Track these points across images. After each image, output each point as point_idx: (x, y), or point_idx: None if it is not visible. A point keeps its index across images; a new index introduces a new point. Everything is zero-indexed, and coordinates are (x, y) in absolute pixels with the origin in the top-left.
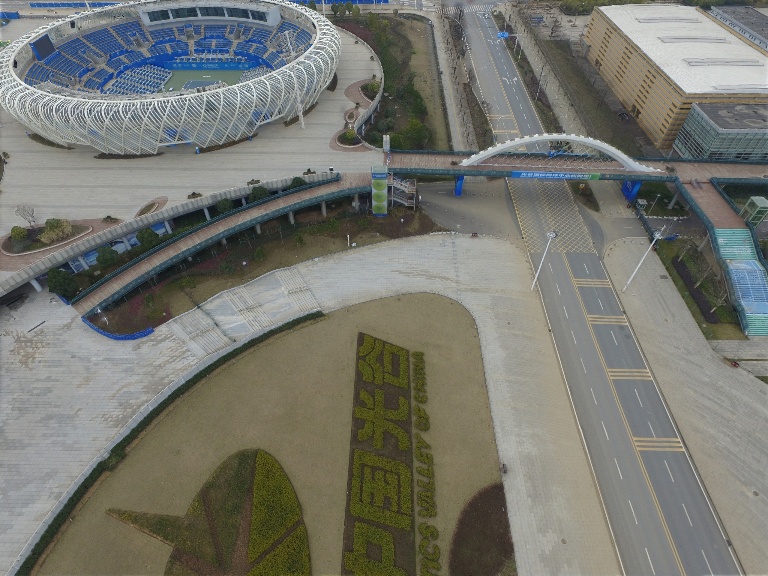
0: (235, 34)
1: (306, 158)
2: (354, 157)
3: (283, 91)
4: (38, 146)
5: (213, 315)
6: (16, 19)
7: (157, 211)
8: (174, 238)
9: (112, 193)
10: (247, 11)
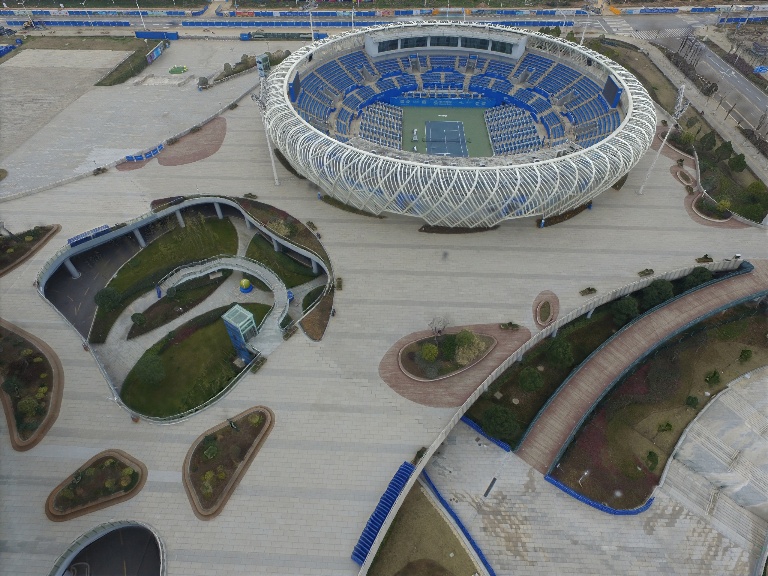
0: (466, 66)
1: (679, 236)
2: (738, 236)
3: (641, 152)
4: (340, 213)
5: (700, 470)
6: (175, 40)
7: (565, 316)
8: (593, 352)
9: (480, 284)
10: (488, 41)
